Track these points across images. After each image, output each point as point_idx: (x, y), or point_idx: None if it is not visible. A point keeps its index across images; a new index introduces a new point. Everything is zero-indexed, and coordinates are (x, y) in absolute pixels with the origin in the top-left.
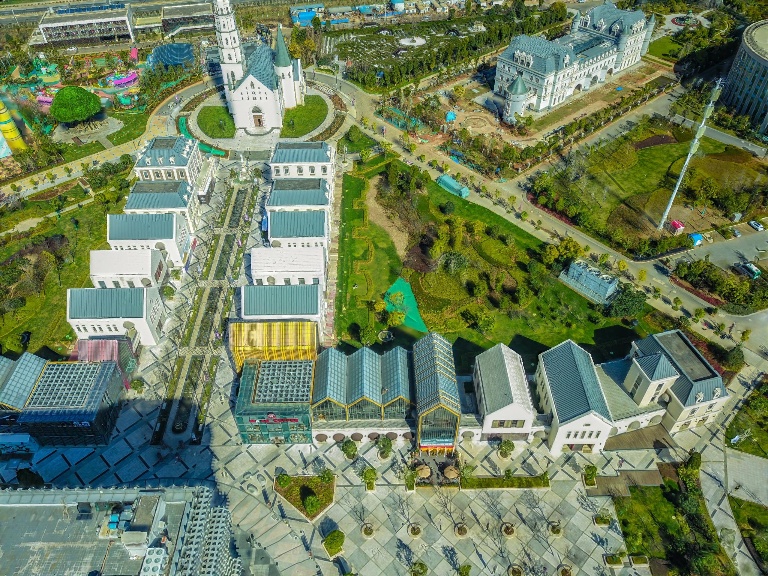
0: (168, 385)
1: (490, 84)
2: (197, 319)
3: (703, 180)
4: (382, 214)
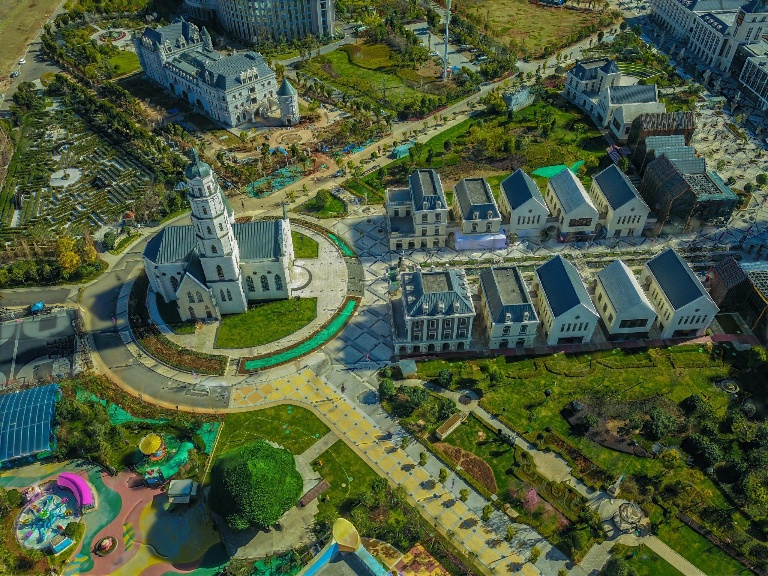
0: (706, 271)
1: (211, 129)
2: (631, 269)
3: (406, 52)
4: (453, 183)
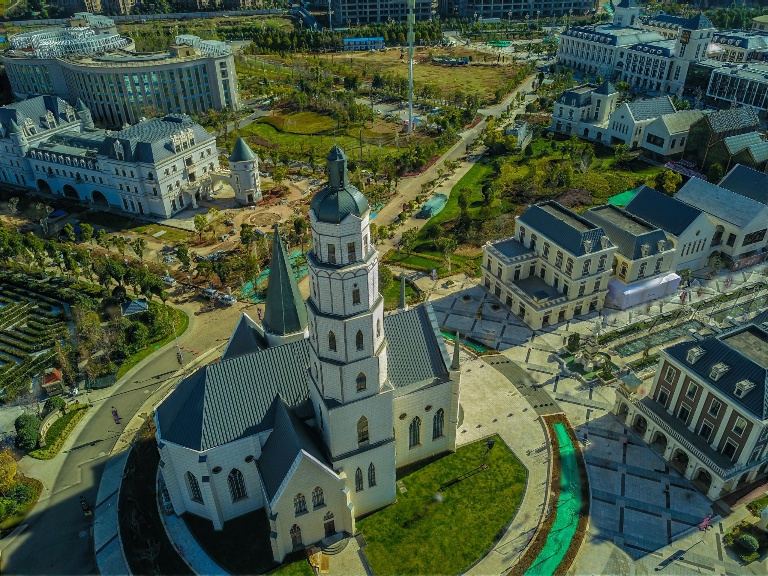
0: None
1: (133, 227)
2: None
3: (352, 110)
4: None
